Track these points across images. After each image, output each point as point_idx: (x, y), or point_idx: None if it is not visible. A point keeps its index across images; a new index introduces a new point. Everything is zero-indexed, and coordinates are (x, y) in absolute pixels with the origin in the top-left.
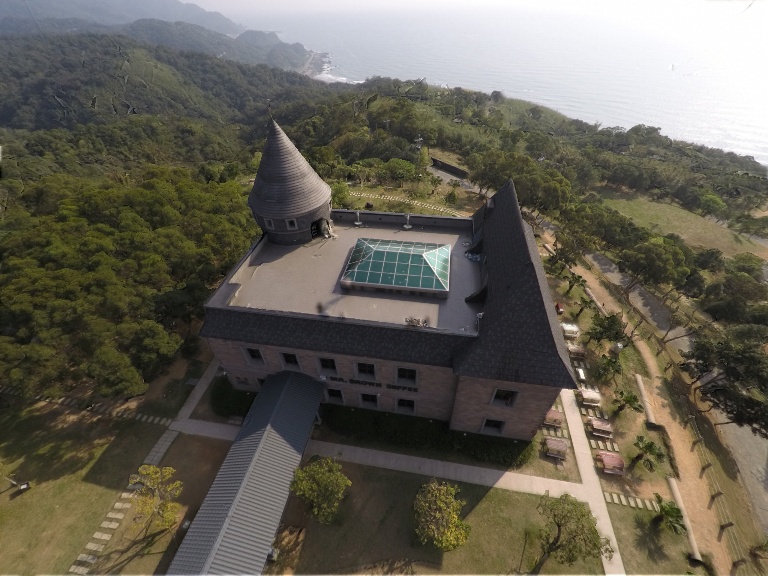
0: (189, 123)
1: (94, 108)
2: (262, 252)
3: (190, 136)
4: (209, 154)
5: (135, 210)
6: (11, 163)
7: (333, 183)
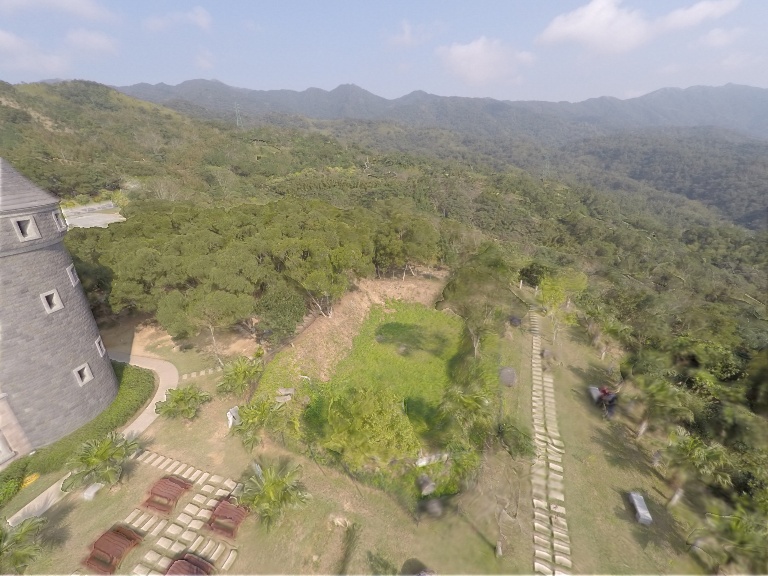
0: None
1: None
2: None
3: None
4: None
5: None
6: (632, 234)
7: (616, 453)
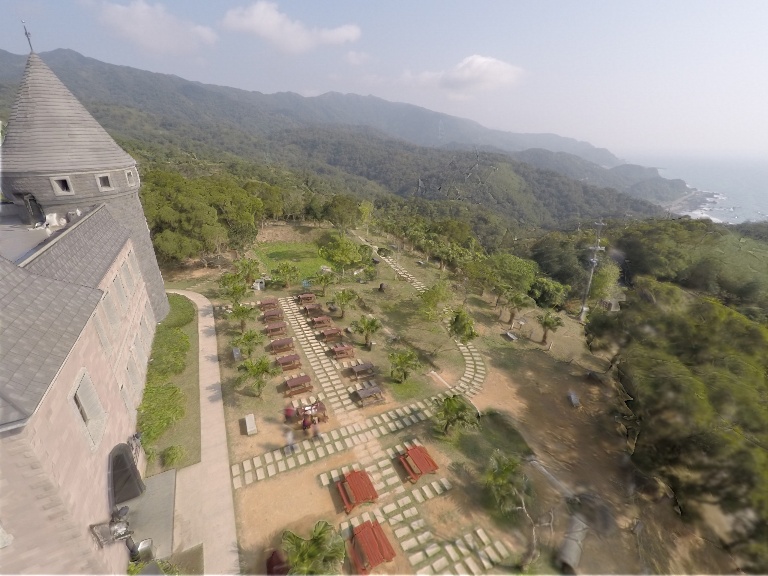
0: (490, 214)
1: (439, 191)
2: (11, 217)
3: (483, 224)
4: (489, 242)
5: (153, 188)
6: None
7: (409, 256)
